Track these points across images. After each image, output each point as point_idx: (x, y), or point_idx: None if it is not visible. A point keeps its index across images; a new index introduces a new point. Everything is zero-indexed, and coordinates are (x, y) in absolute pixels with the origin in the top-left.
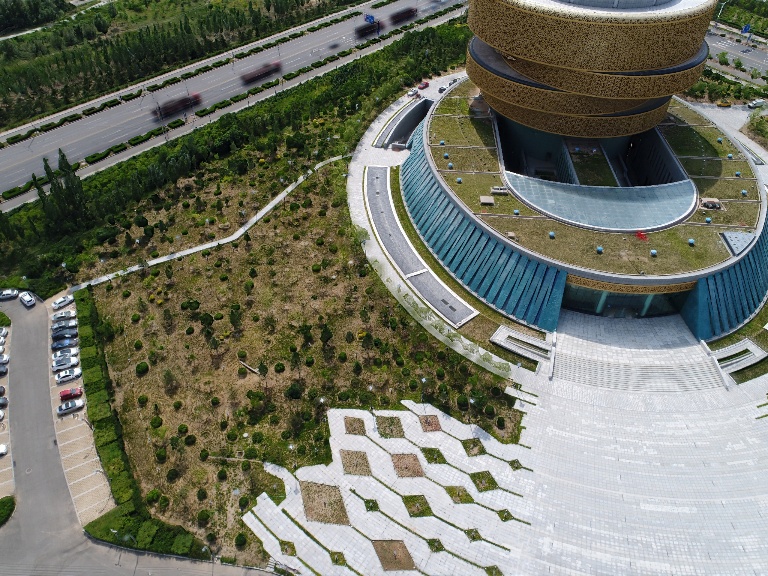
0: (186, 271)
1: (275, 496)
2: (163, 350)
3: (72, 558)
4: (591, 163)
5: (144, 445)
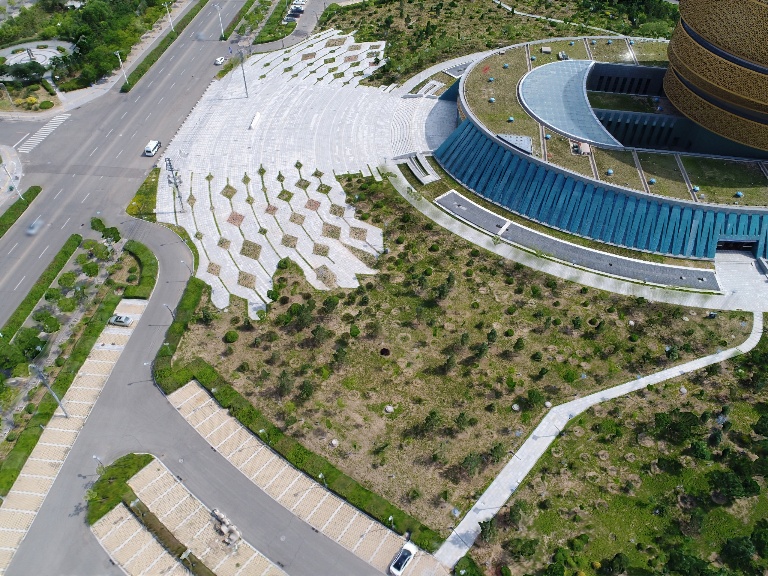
0: (483, 4)
1: (341, 33)
2: (424, 5)
3: (323, 4)
4: (633, 103)
5: (369, 7)
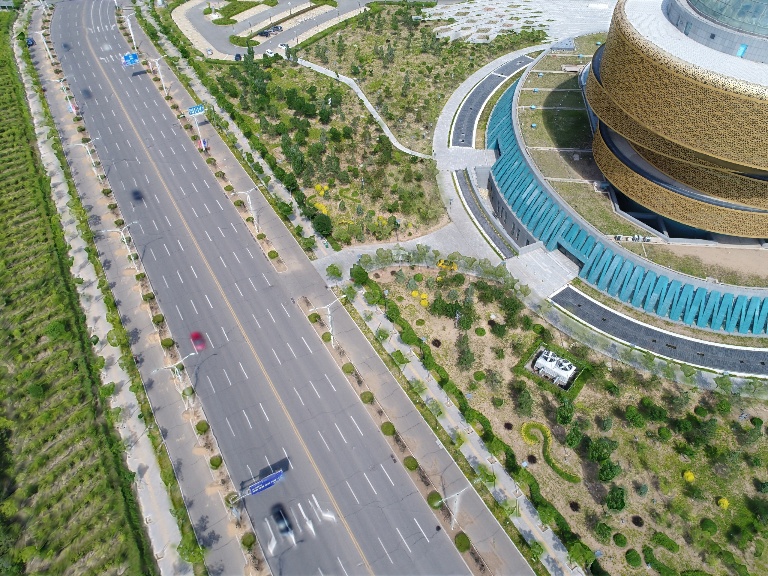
0: None
1: None
2: None
3: None
4: None
5: None
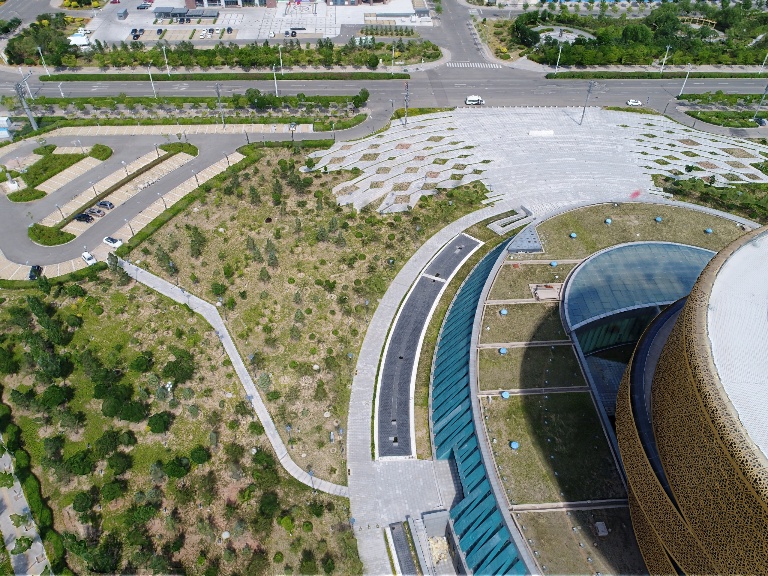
0: None
1: (765, 153)
2: None
3: None
4: None
5: None
